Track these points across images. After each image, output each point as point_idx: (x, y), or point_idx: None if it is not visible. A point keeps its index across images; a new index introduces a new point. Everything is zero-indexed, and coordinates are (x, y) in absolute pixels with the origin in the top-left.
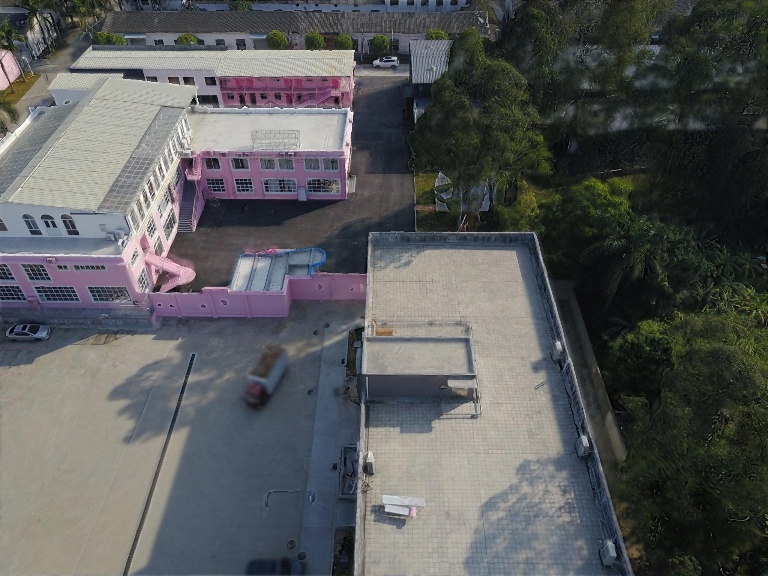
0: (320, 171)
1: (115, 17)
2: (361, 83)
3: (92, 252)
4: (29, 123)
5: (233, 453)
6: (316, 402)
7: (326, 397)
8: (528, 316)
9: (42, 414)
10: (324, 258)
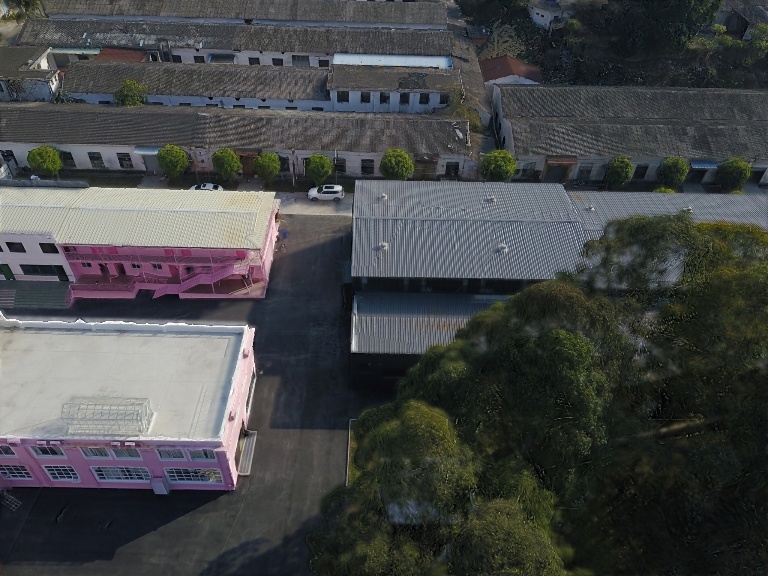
0: (185, 460)
1: None
2: (288, 230)
3: None
4: None
5: None
6: None
7: None
8: None
9: None
10: None
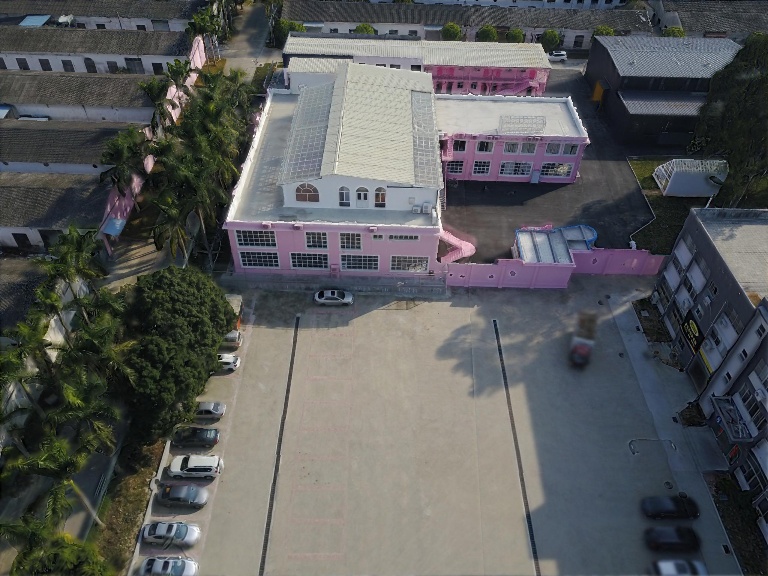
0: (558, 155)
1: (291, 6)
2: None
3: (405, 223)
4: (270, 104)
5: (575, 407)
6: (631, 364)
7: (638, 359)
8: None
9: (382, 371)
10: (596, 235)
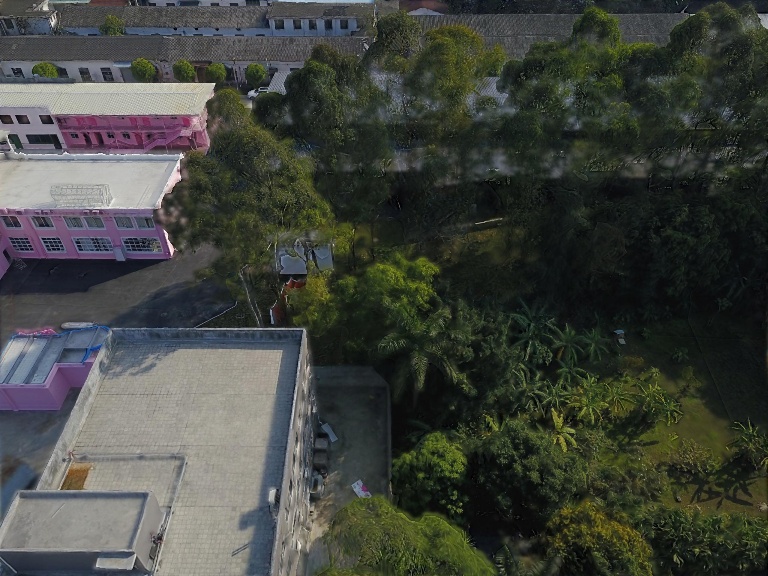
0: (135, 229)
1: None
2: None
3: None
4: None
5: None
6: None
7: None
8: (264, 444)
9: None
10: None
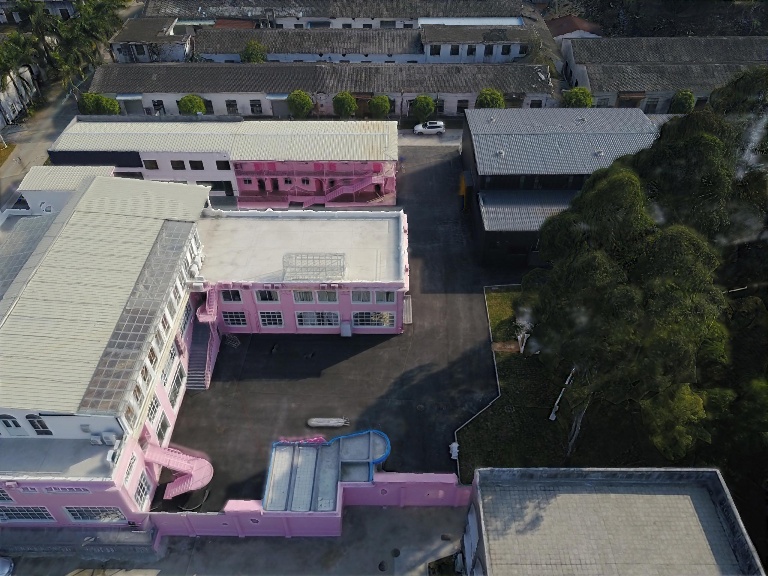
0: (371, 304)
1: (105, 73)
2: (403, 157)
3: (70, 467)
4: None
5: None
6: None
7: None
8: None
9: None
10: (388, 450)
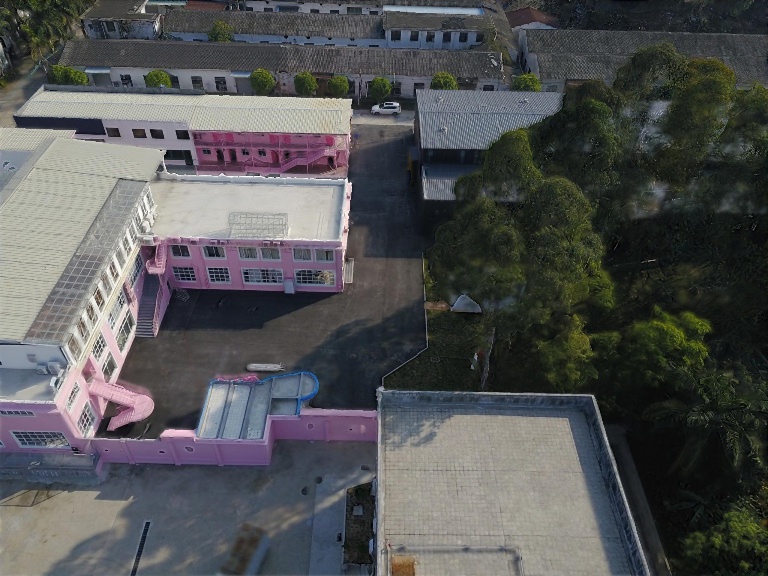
0: (312, 262)
1: (75, 47)
2: (358, 134)
3: (16, 392)
4: None
5: None
6: None
7: None
8: (595, 535)
9: None
10: (316, 388)
